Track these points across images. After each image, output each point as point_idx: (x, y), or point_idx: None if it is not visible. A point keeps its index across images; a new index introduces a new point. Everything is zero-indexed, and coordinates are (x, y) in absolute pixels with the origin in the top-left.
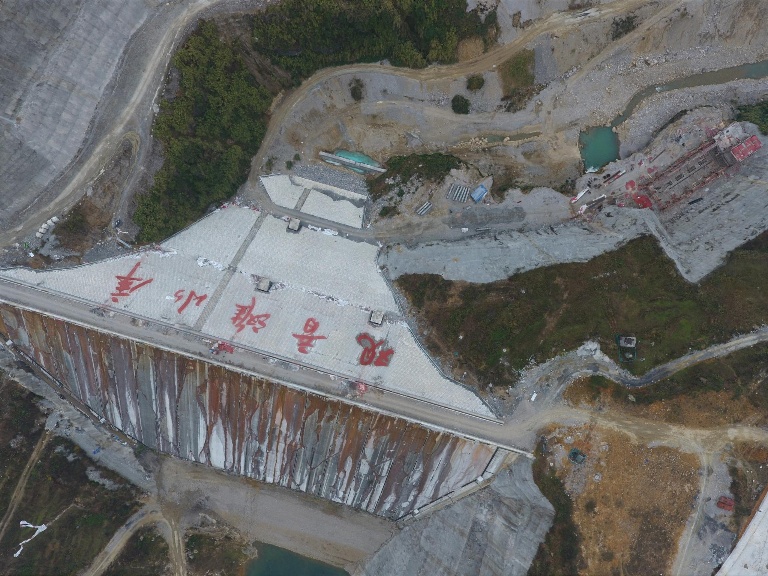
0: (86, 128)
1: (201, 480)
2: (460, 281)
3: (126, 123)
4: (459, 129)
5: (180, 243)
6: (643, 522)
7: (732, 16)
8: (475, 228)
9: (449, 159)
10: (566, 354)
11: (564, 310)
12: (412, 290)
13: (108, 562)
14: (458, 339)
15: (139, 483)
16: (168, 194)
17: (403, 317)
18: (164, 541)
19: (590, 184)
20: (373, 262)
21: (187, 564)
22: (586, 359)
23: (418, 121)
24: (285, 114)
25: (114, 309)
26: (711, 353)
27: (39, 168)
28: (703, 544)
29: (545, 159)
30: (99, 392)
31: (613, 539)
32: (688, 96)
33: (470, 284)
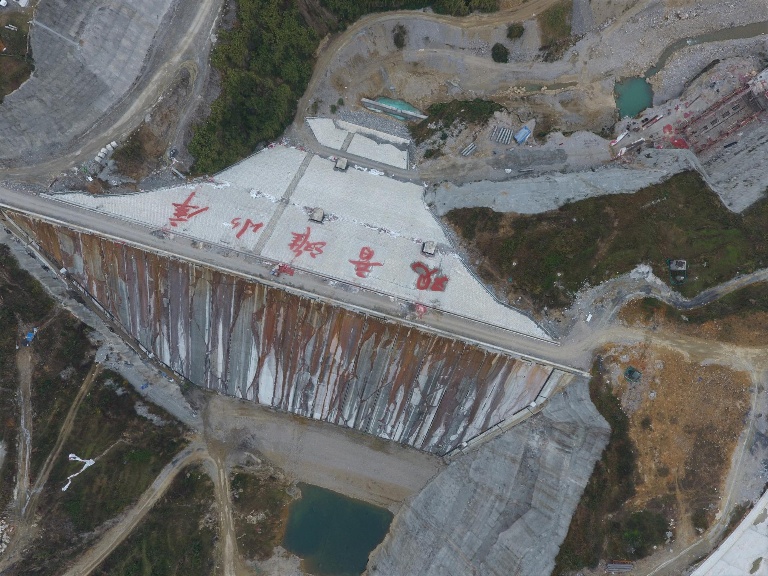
0: (144, 56)
1: (248, 417)
2: (510, 213)
3: (184, 52)
4: (498, 78)
5: (232, 176)
6: (697, 438)
7: None
8: (518, 169)
9: (491, 104)
10: (619, 277)
11: (615, 236)
12: (462, 223)
13: (155, 499)
14: (512, 266)
15: (186, 420)
16: (222, 126)
17: (454, 249)
18: (210, 479)
19: (629, 128)
20: (420, 200)
21: (232, 503)
22: (639, 281)
23: (458, 69)
24: (331, 58)
25: (174, 231)
26: (758, 277)
27: (99, 93)
28: (755, 459)
29: (582, 108)
30: (150, 324)
31: (668, 455)
32: (718, 49)
33: (521, 215)
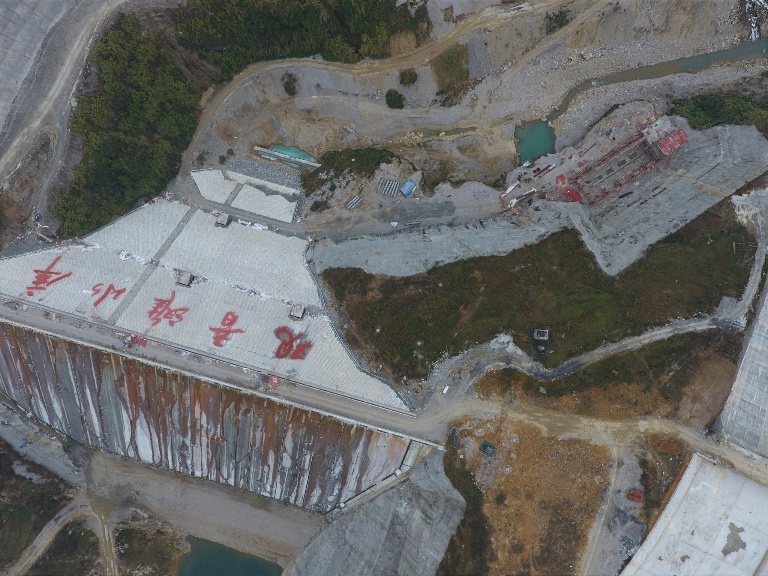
0: (3, 122)
1: (130, 474)
2: (381, 275)
3: (44, 117)
4: (394, 124)
5: (104, 237)
6: (553, 514)
7: (666, 10)
8: (405, 222)
9: (381, 153)
10: (479, 347)
11: (480, 303)
12: (334, 284)
13: (36, 556)
14: (375, 332)
15: (68, 477)
16: (89, 188)
17: (325, 311)
18: (94, 535)
19: (520, 178)
20: (301, 256)
21: (118, 558)
22: (499, 352)
23: (353, 116)
24: (216, 109)
25: (27, 302)
26: (625, 346)
27: None
28: (613, 536)
29: (480, 154)
30: (22, 386)
31: (523, 531)
32: (624, 90)
33: (390, 277)
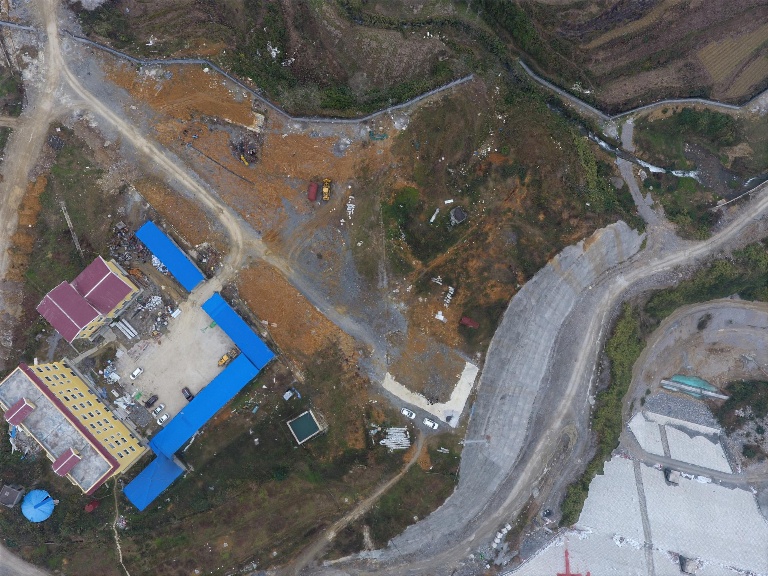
0: (526, 425)
1: None
2: None
3: (563, 417)
4: None
5: (589, 518)
6: None
7: None
8: None
9: None
10: None
11: None
12: None
13: None
14: None
15: None
16: None
17: None
18: None
19: None
20: (759, 516)
21: None
22: None
23: (756, 346)
24: (646, 356)
25: None
26: None
27: (493, 476)
28: None
29: None
30: None
31: None
32: None
33: None
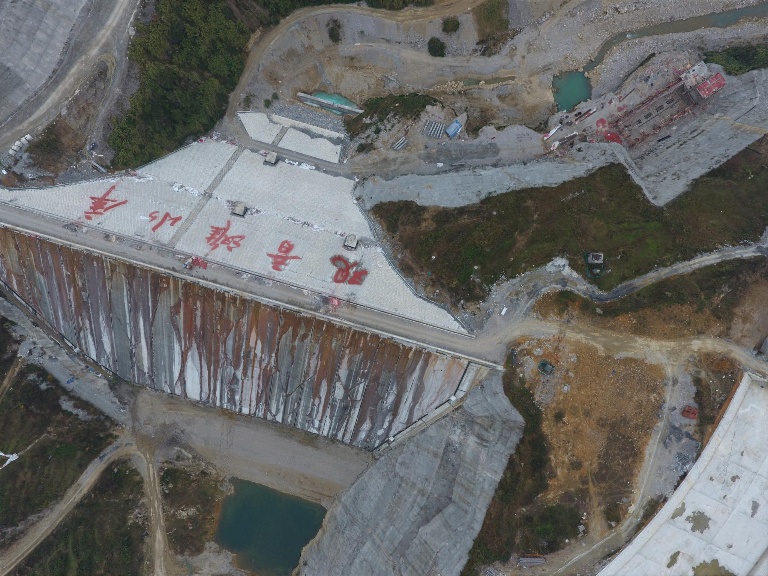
0: (61, 49)
1: (177, 412)
2: (433, 206)
3: (102, 45)
4: (435, 72)
5: (156, 170)
6: (610, 431)
7: None
8: (450, 163)
9: (425, 98)
10: (535, 270)
11: (534, 230)
12: (387, 216)
13: (81, 494)
14: (431, 259)
15: (114, 415)
16: (144, 119)
17: (378, 243)
18: (139, 474)
19: (562, 121)
20: (349, 194)
21: (162, 498)
22: (555, 274)
23: (395, 63)
24: (263, 52)
25: (87, 225)
26: (676, 270)
27: (13, 86)
28: (669, 453)
29: (519, 102)
30: (73, 318)
31: (581, 448)
32: (657, 43)
33: (443, 208)
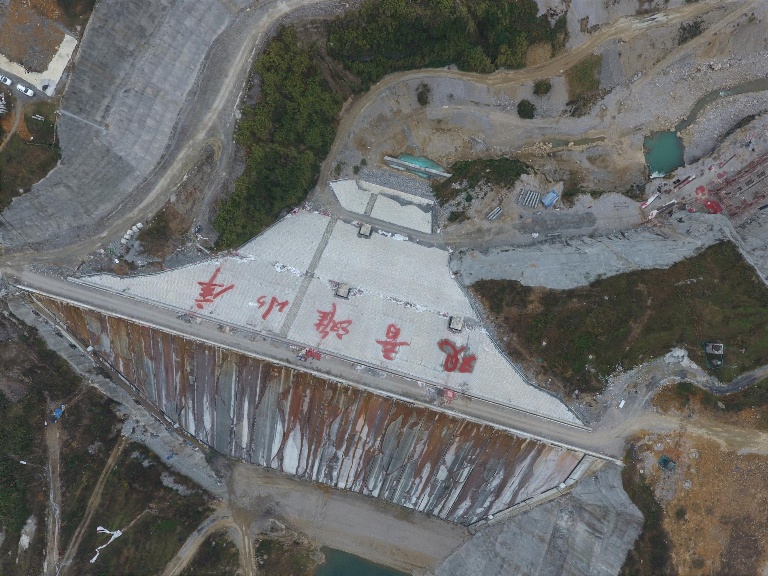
0: (169, 134)
1: (272, 485)
2: (539, 287)
3: (208, 129)
4: (524, 134)
5: (257, 249)
6: (733, 529)
7: None
8: (545, 233)
9: (517, 164)
10: (653, 361)
11: (649, 317)
12: (490, 296)
13: (181, 568)
14: (541, 345)
15: (211, 488)
16: (247, 200)
17: (481, 323)
18: (235, 546)
19: (660, 189)
20: (445, 267)
21: (257, 569)
22: (674, 366)
23: (483, 126)
24: (354, 119)
25: (201, 315)
26: None
27: (124, 174)
28: None
29: (610, 164)
30: (176, 398)
31: (703, 546)
32: (752, 101)
33: (550, 290)
